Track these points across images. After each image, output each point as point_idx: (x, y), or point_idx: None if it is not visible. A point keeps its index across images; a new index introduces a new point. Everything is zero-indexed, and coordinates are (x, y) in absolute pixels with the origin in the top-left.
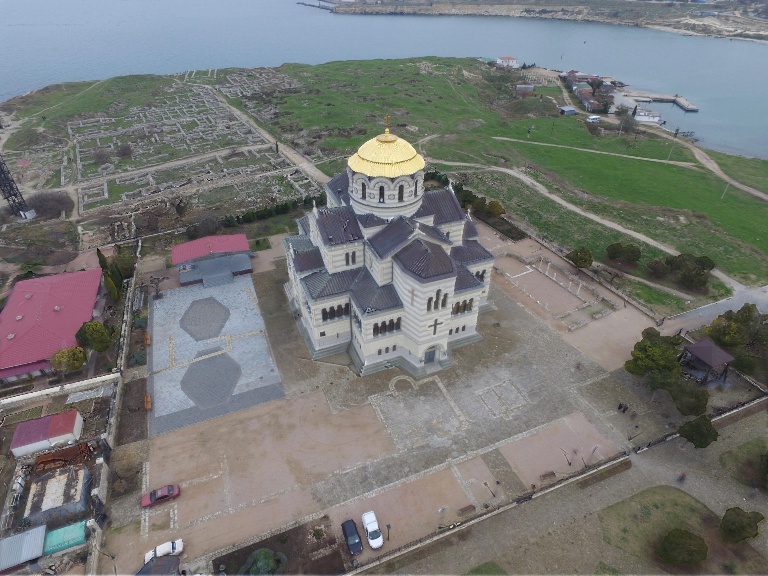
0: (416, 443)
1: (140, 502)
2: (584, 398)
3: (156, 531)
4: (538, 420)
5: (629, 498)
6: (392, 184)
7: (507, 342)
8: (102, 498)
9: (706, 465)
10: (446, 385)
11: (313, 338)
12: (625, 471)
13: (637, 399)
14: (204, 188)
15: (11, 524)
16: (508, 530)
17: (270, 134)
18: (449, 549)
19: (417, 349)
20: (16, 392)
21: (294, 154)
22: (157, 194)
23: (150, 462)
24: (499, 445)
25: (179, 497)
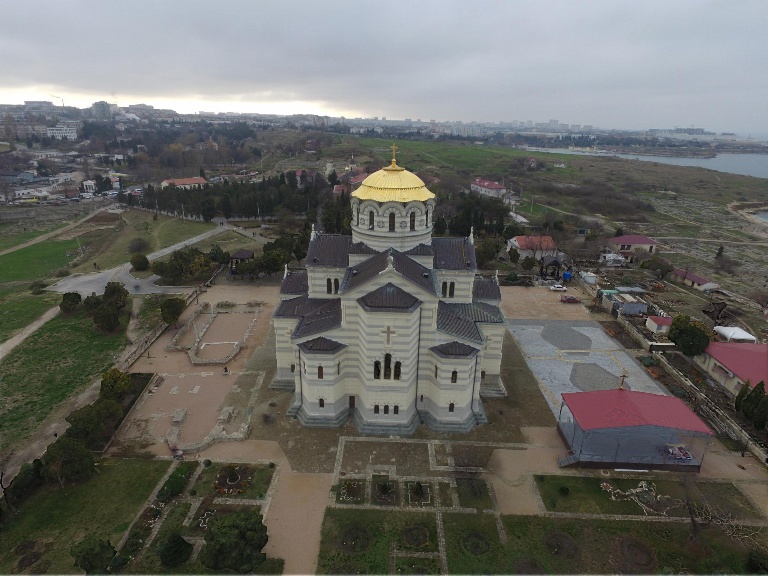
0: None
1: None
2: None
3: None
4: None
5: None
6: None
7: None
8: None
9: None
10: None
11: None
12: None
13: None
14: None
15: (644, 298)
16: None
17: None
18: None
19: None
20: None
21: None
22: None
23: None
24: None
25: None
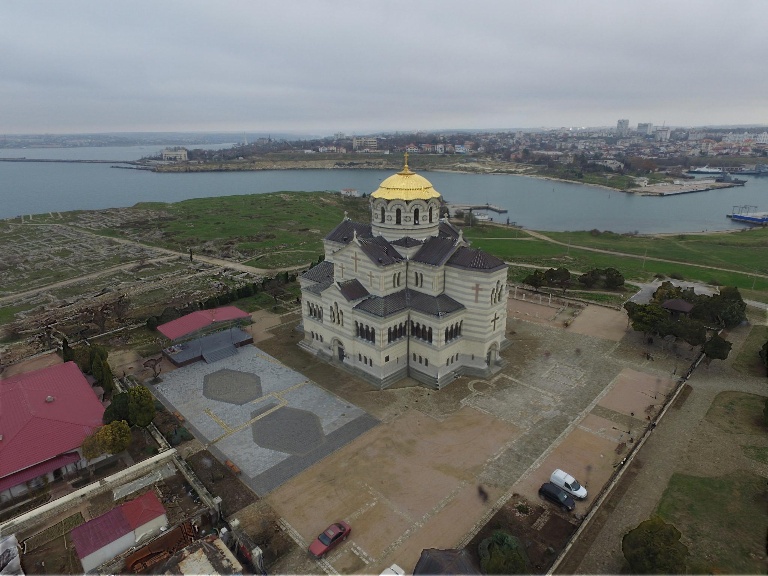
0: (533, 420)
1: (308, 555)
2: (620, 359)
3: (353, 573)
4: (605, 380)
5: (712, 405)
6: (426, 205)
7: (531, 341)
8: None
9: (731, 374)
10: (515, 377)
11: (373, 369)
12: (692, 391)
13: (652, 351)
14: (130, 293)
15: None
16: (662, 450)
17: (169, 249)
18: (637, 477)
19: (483, 348)
20: (25, 509)
21: (211, 259)
22: (70, 306)
23: (284, 517)
24: (596, 402)
25: (350, 534)
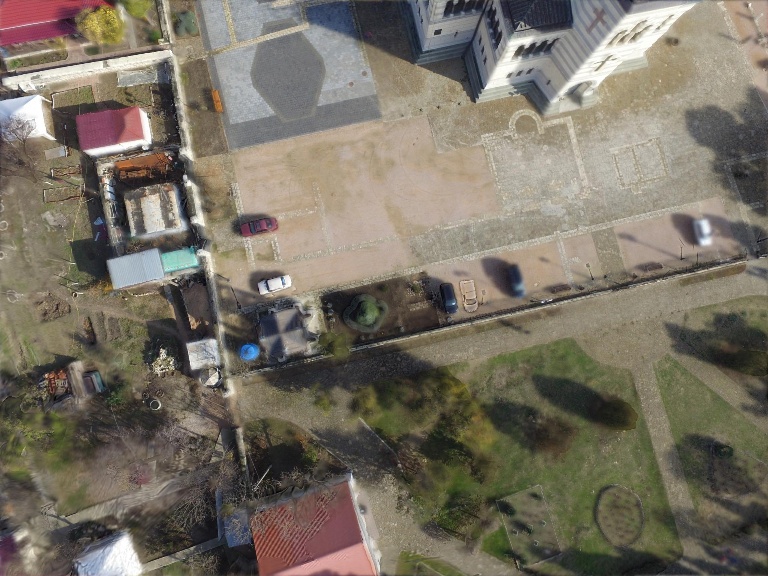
0: (526, 207)
1: (239, 229)
2: (736, 180)
3: (262, 261)
4: (670, 200)
5: (723, 303)
6: None
7: (677, 76)
8: (201, 222)
9: None
10: (578, 133)
11: (421, 30)
12: (734, 275)
13: None
14: None
15: (121, 239)
16: (595, 313)
17: None
18: (536, 321)
19: (562, 85)
20: (49, 59)
21: None
22: None
23: (238, 184)
24: (616, 224)
25: (277, 229)
